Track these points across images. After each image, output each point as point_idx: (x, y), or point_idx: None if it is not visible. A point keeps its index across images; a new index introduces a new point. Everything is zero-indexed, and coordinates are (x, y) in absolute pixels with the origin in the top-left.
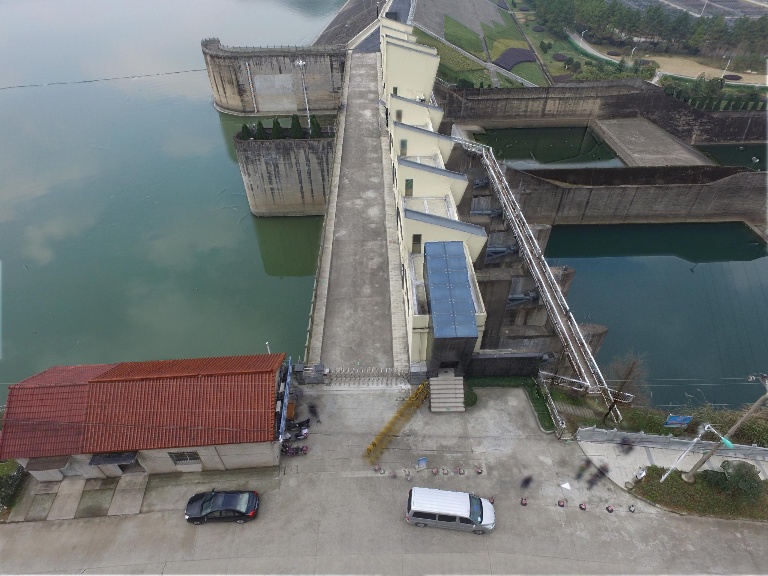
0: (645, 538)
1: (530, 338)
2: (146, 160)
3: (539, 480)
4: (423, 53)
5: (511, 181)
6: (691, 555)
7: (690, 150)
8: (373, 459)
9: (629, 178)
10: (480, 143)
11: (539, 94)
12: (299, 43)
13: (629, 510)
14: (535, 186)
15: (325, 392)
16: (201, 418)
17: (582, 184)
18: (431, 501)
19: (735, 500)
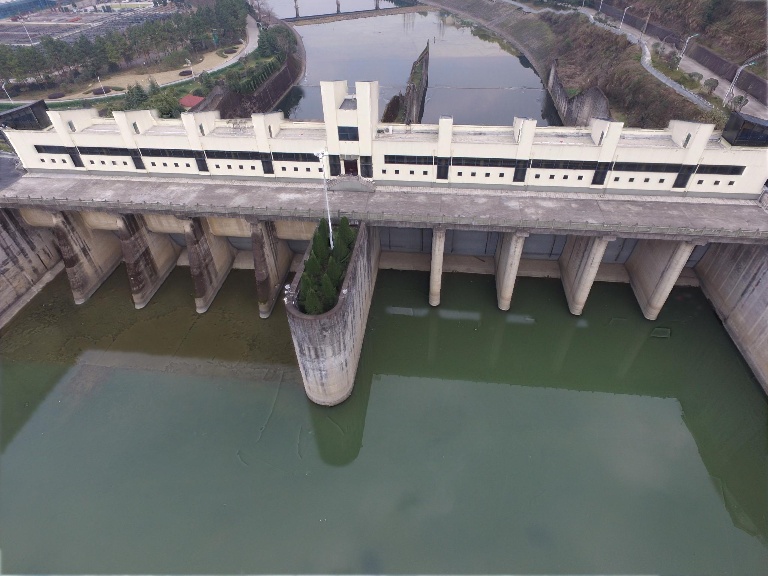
0: None
1: None
2: None
3: None
4: None
5: None
6: None
7: None
8: None
9: None
10: None
11: None
12: None
13: None
14: None
15: None
16: None
17: None
18: None
19: None
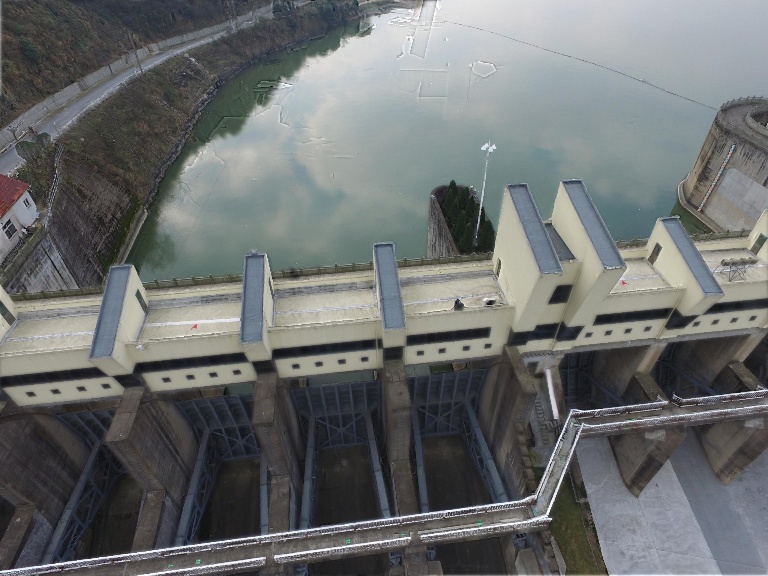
0: None
1: None
2: (521, 174)
3: None
4: (542, 244)
5: None
6: None
7: None
8: None
9: None
10: None
11: None
12: None
13: None
14: None
15: None
16: None
17: None
18: None
19: None
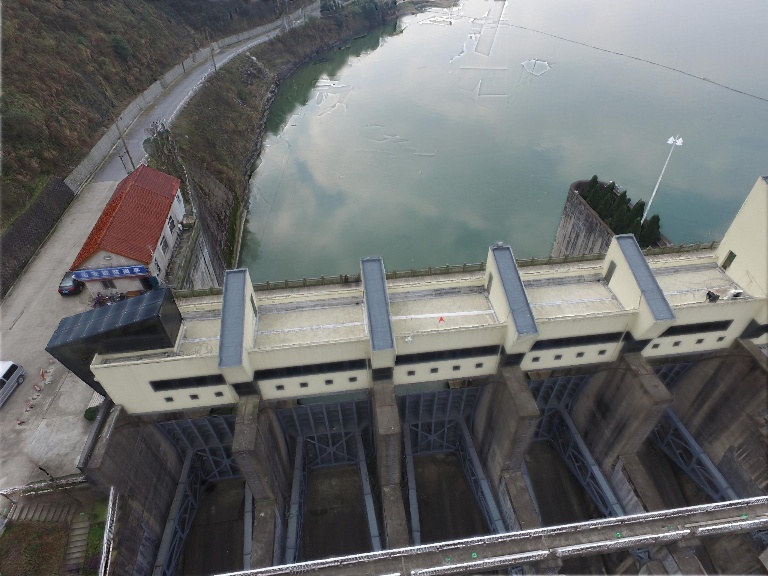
0: None
1: None
2: (609, 171)
3: None
4: None
5: None
6: None
7: None
8: None
9: None
10: None
11: None
12: None
13: None
14: None
15: None
16: None
17: None
18: None
19: None
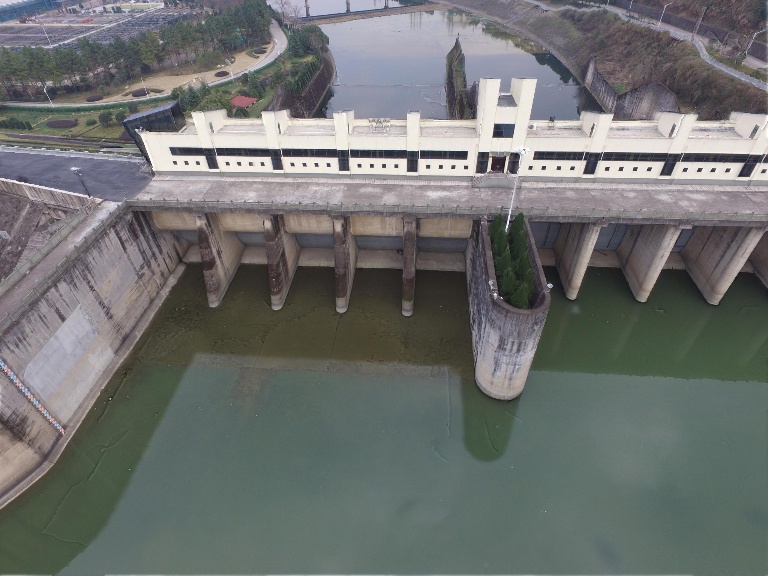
0: None
1: None
2: None
3: None
4: None
5: None
6: None
7: None
8: None
9: None
10: None
11: None
12: None
13: None
14: None
15: None
16: None
17: None
18: None
19: None
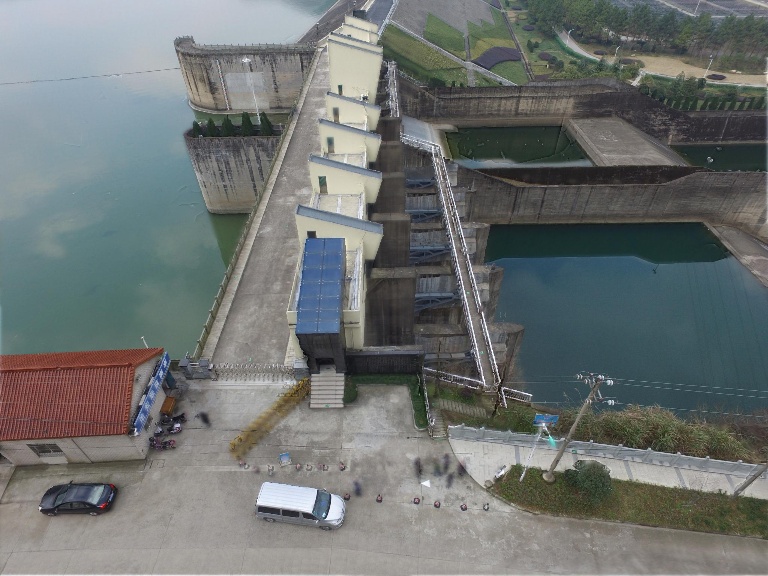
0: (492, 536)
1: (445, 336)
2: (113, 157)
3: (401, 477)
4: (366, 51)
5: (464, 180)
6: (534, 554)
7: (663, 150)
8: (240, 454)
9: (586, 178)
10: (451, 142)
11: (511, 93)
12: (284, 41)
13: (483, 508)
14: (488, 185)
15: (210, 387)
16: (56, 410)
17: (539, 183)
18: (277, 496)
19: (590, 500)
